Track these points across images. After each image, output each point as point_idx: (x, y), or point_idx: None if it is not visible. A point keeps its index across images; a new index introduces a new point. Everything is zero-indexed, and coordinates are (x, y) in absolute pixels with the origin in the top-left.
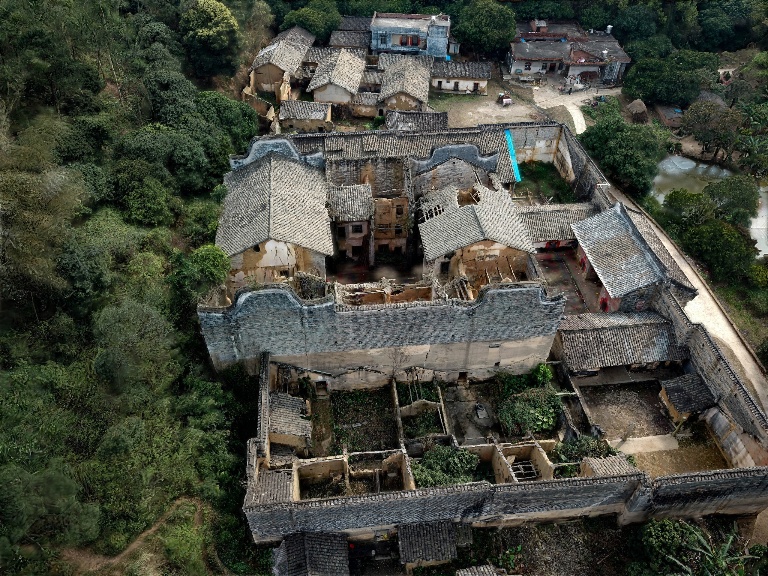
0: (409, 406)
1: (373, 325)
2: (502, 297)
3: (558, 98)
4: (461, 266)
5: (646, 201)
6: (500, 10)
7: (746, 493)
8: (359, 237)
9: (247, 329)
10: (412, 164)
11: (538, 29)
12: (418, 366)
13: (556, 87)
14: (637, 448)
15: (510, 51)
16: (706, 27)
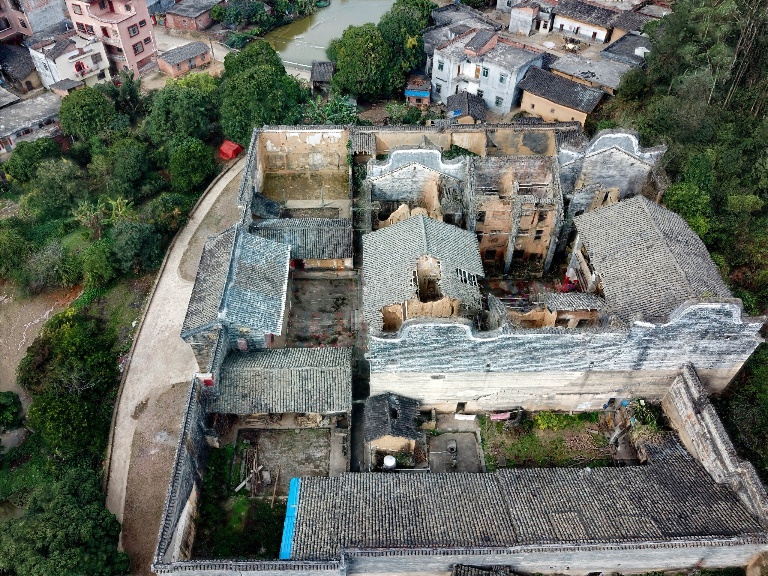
0: None
1: None
2: None
3: None
4: None
5: None
6: None
7: None
8: None
9: None
10: None
11: None
12: None
13: None
14: (317, 202)
15: None
16: None
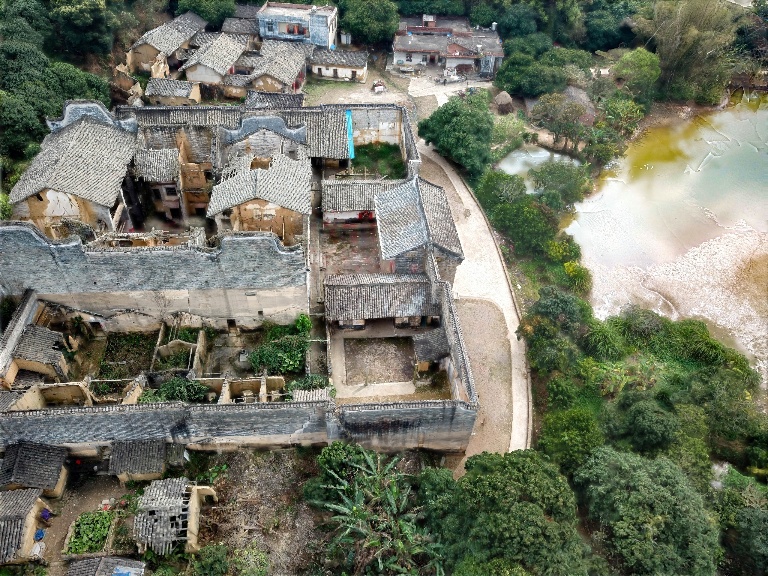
0: (166, 345)
1: (125, 267)
2: (240, 245)
3: (432, 88)
4: (237, 223)
5: (482, 183)
6: (382, 3)
7: (436, 426)
8: (175, 200)
9: (4, 265)
10: (224, 133)
11: (426, 23)
12: (184, 311)
13: (433, 78)
14: (375, 392)
15: (393, 43)
16: (590, 28)
